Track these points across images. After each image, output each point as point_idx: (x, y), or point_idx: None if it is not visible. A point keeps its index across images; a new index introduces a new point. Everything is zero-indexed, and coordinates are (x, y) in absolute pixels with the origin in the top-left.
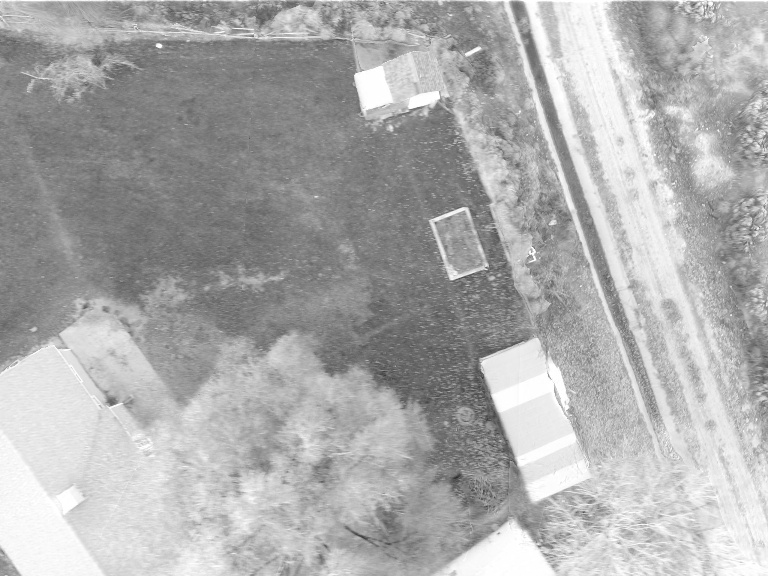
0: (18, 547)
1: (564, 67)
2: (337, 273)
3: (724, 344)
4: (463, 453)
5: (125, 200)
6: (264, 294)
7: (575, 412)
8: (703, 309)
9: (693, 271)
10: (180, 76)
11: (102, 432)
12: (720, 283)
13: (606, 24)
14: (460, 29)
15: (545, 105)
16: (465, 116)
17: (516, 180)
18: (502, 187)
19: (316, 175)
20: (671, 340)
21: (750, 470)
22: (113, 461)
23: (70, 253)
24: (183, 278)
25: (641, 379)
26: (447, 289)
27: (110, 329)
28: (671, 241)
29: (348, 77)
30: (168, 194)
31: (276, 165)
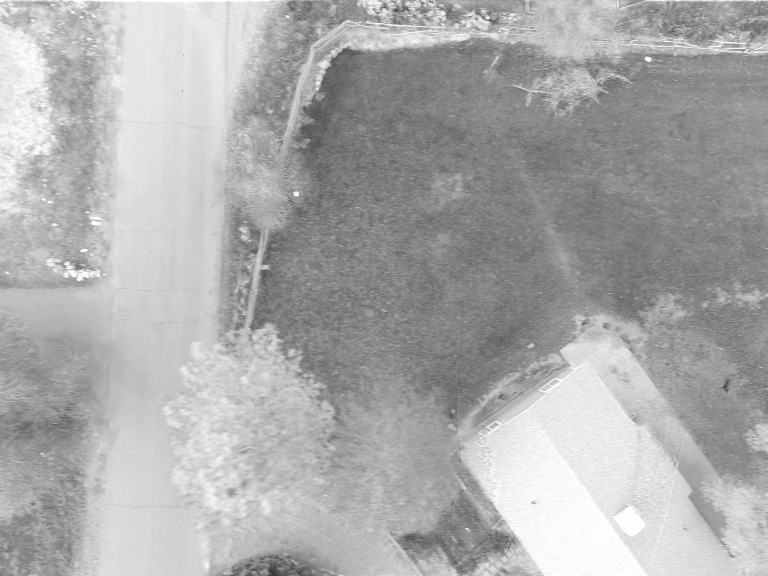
0: (560, 568)
1: None
2: None
3: None
4: None
5: (621, 215)
6: (761, 311)
7: None
8: None
9: None
10: (670, 90)
11: (643, 452)
12: None
13: None
14: None
15: None
16: None
17: None
18: None
19: None
20: None
21: None
22: (655, 481)
23: (567, 269)
24: (681, 295)
25: None
26: None
27: (611, 346)
28: None
29: None
30: (664, 210)
31: None
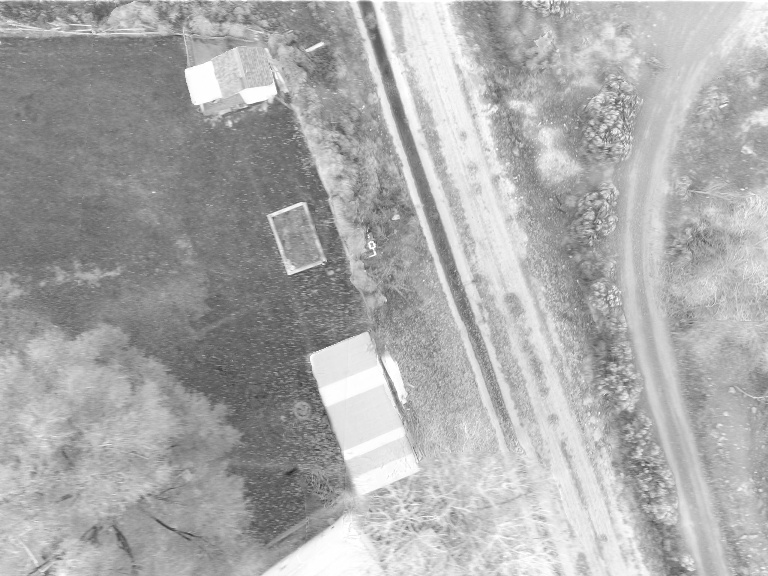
0: None
1: (408, 62)
2: (174, 268)
3: (566, 338)
4: (300, 447)
5: None
6: (100, 289)
7: (413, 406)
8: (545, 303)
9: (535, 265)
10: (18, 72)
11: None
12: (563, 277)
13: (449, 19)
14: (303, 24)
15: (392, 100)
16: (302, 111)
17: (353, 175)
18: (337, 182)
19: (154, 171)
20: (514, 334)
21: (592, 464)
22: None
23: None
24: (19, 274)
25: (487, 373)
26: (285, 284)
27: None
28: (514, 235)
29: None
30: (4, 190)
31: (113, 161)
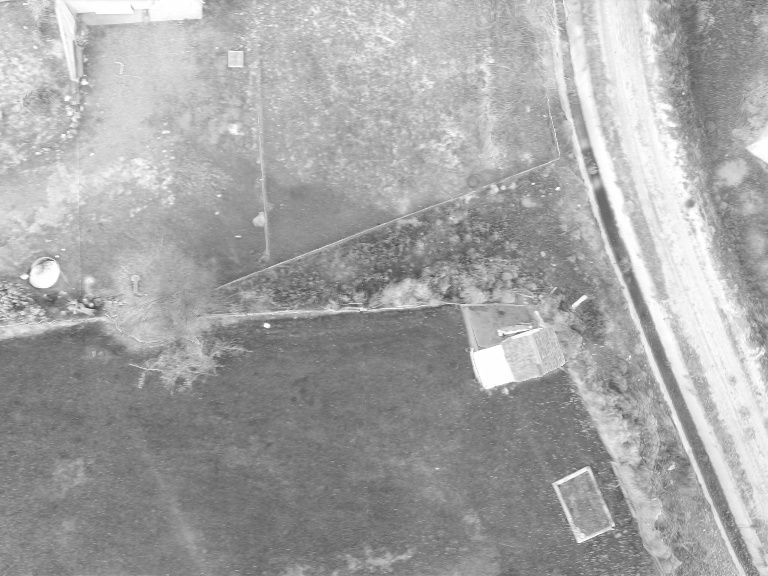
0: None
1: (671, 309)
2: (464, 545)
3: None
4: None
5: (245, 489)
6: (393, 574)
7: None
8: None
9: None
10: (291, 355)
11: None
12: None
13: (710, 264)
14: (565, 279)
15: (652, 343)
16: (581, 377)
17: (637, 437)
18: (625, 449)
19: (435, 446)
20: None
21: None
22: None
23: (193, 548)
24: (310, 565)
25: None
26: (575, 551)
27: None
28: None
29: (459, 343)
30: (288, 480)
31: (395, 440)
